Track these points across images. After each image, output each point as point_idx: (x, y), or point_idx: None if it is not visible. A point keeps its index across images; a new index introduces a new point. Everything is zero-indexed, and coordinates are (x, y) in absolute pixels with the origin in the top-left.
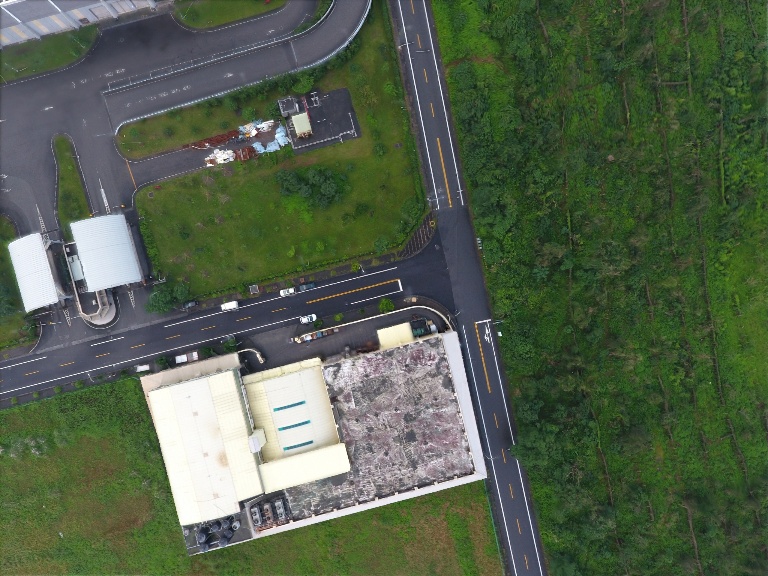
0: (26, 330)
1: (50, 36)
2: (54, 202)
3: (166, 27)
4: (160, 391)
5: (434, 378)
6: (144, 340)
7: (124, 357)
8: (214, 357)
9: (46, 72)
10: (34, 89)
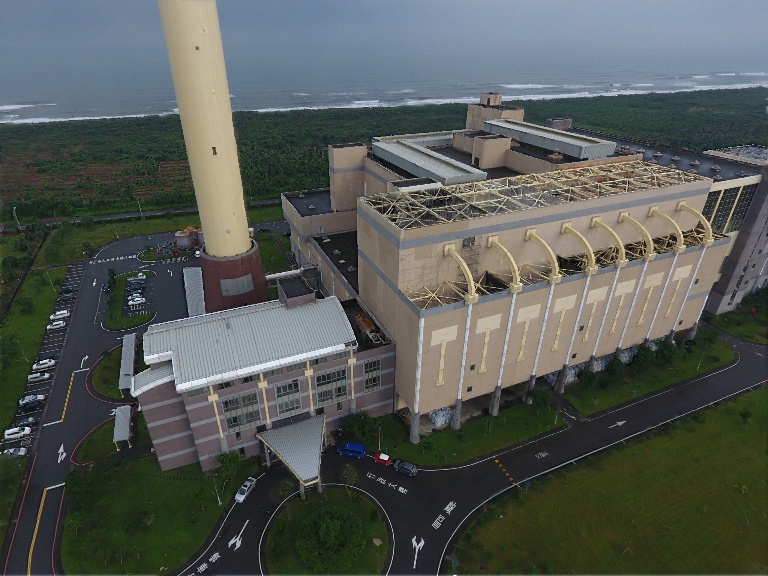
0: None
1: None
2: None
3: None
4: None
5: None
6: None
7: None
8: None
9: None
10: None
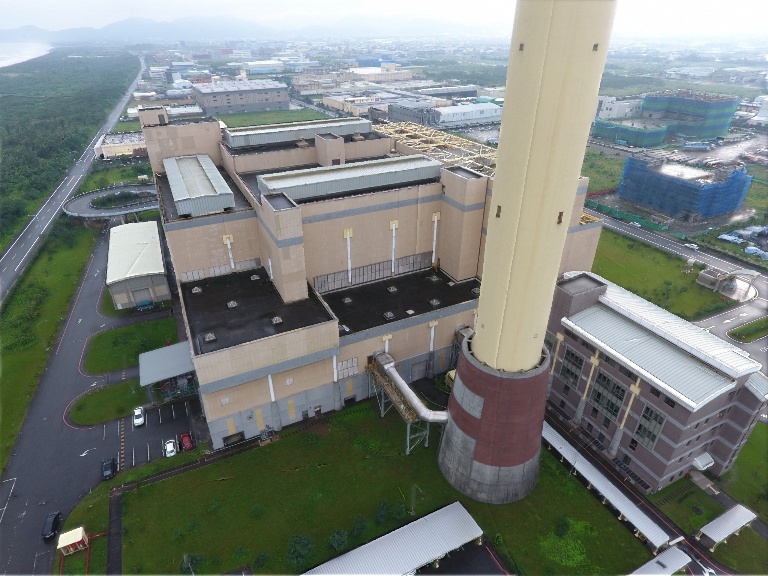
0: None
1: None
2: None
3: None
4: None
5: (111, 142)
6: None
7: None
8: None
9: None
10: None
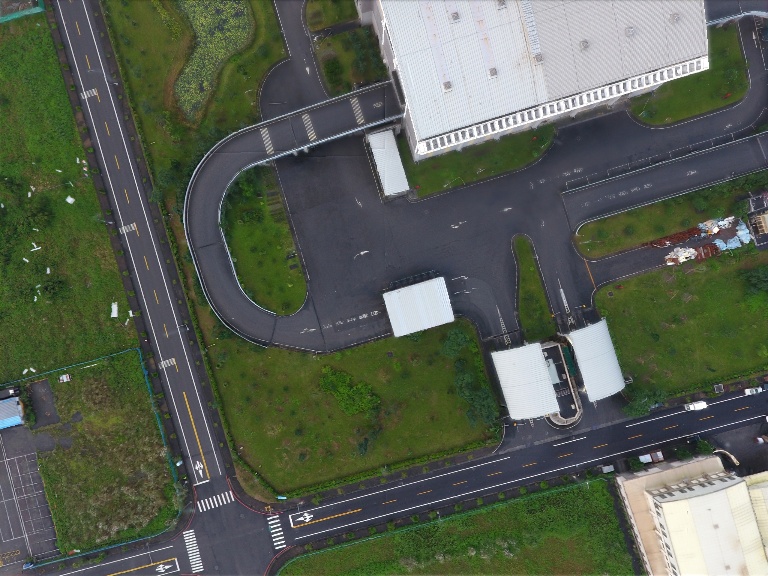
0: (492, 432)
1: (507, 136)
2: (514, 303)
3: (623, 124)
4: (677, 503)
5: None
6: (606, 440)
7: (587, 457)
8: (695, 461)
9: (504, 173)
10: (492, 190)
